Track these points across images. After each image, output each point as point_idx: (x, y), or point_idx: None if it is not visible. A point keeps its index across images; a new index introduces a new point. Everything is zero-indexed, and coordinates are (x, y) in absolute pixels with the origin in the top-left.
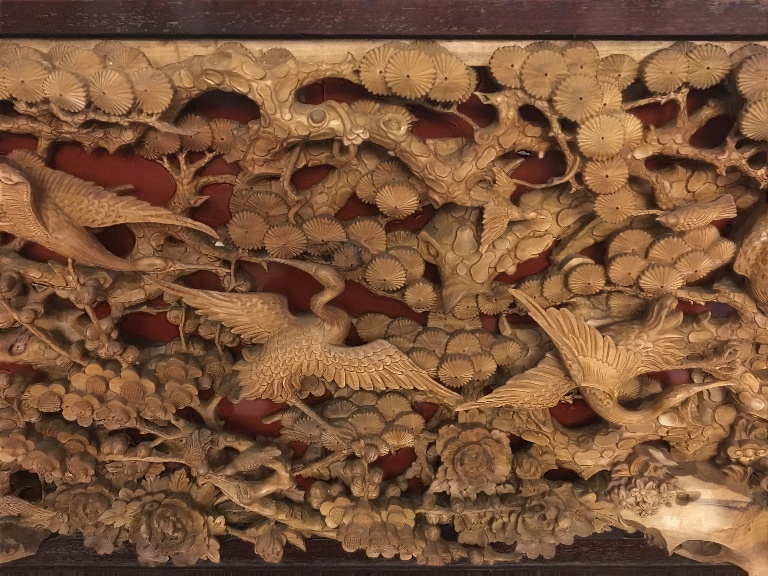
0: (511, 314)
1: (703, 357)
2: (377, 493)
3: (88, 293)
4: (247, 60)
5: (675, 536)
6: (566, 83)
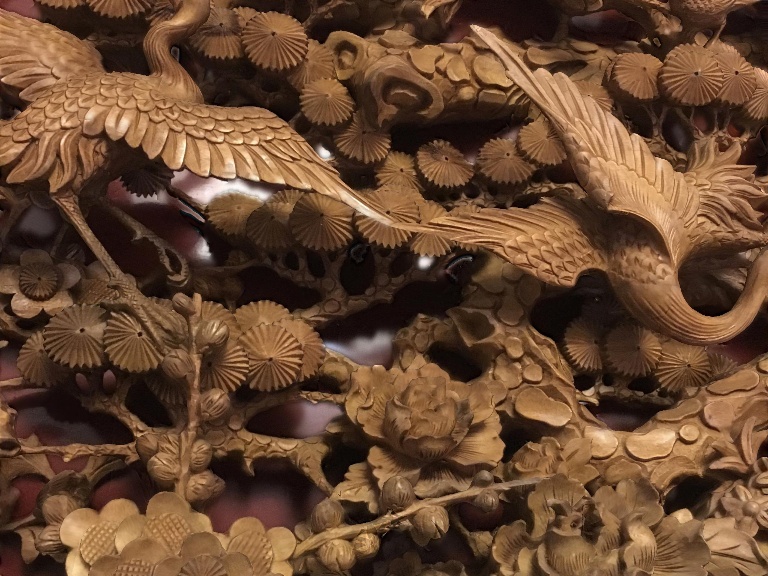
0: None
1: None
2: (209, 481)
3: None
4: None
5: None
6: None
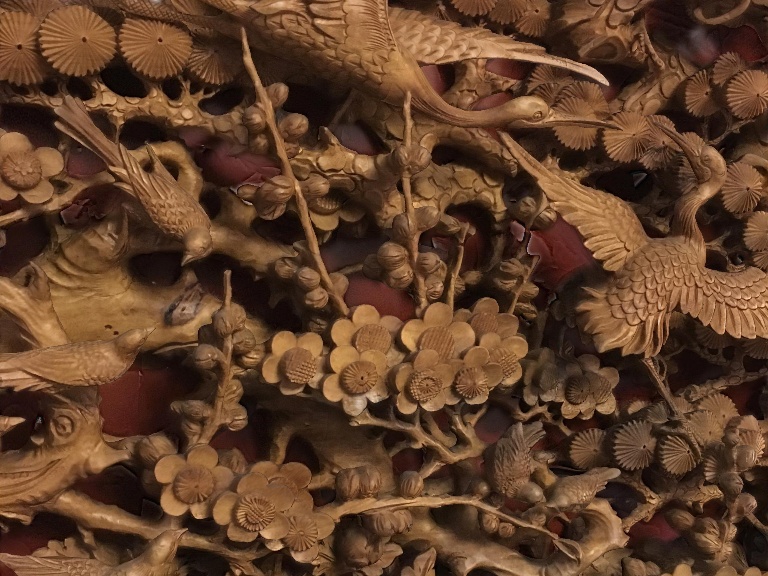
0: None
1: None
2: None
3: (426, 150)
4: None
5: None
6: None
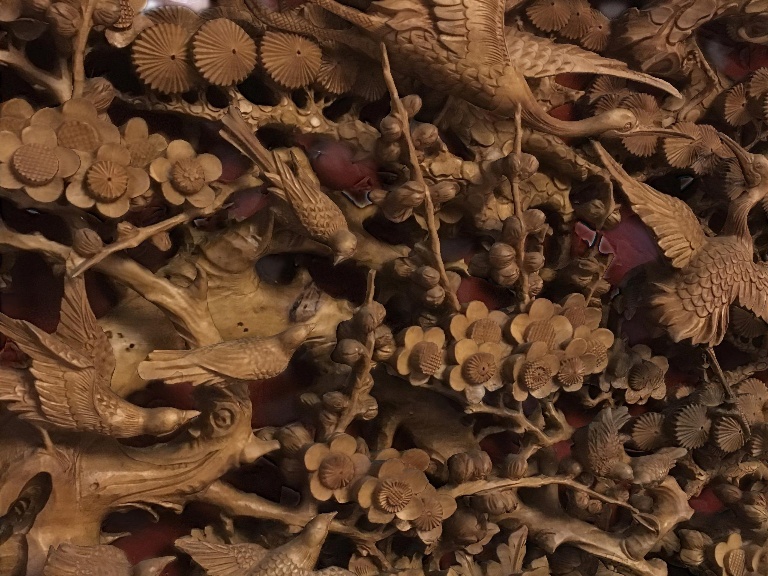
0: None
1: None
2: None
3: None
4: None
5: None
6: None
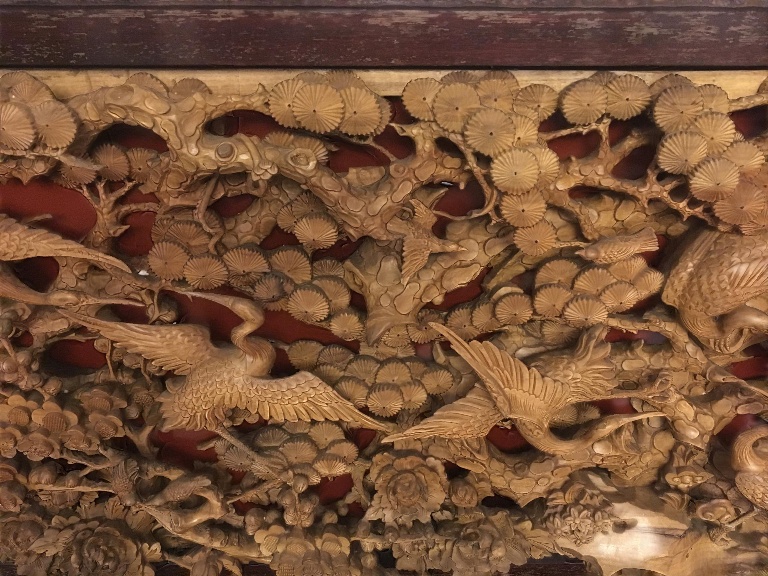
0: (444, 341)
1: (638, 385)
2: (311, 521)
3: (2, 327)
4: (150, 94)
5: (611, 564)
6: (476, 118)
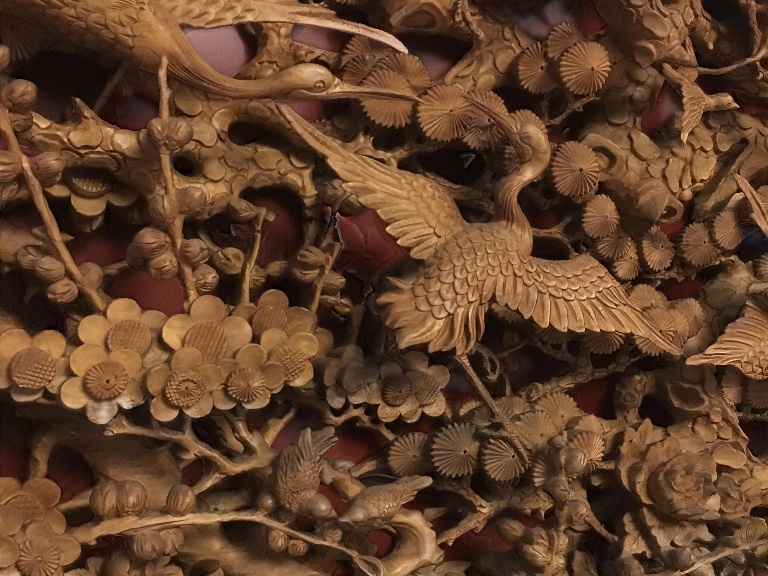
0: (668, 280)
1: None
2: (564, 559)
3: (185, 122)
4: None
5: None
6: None
